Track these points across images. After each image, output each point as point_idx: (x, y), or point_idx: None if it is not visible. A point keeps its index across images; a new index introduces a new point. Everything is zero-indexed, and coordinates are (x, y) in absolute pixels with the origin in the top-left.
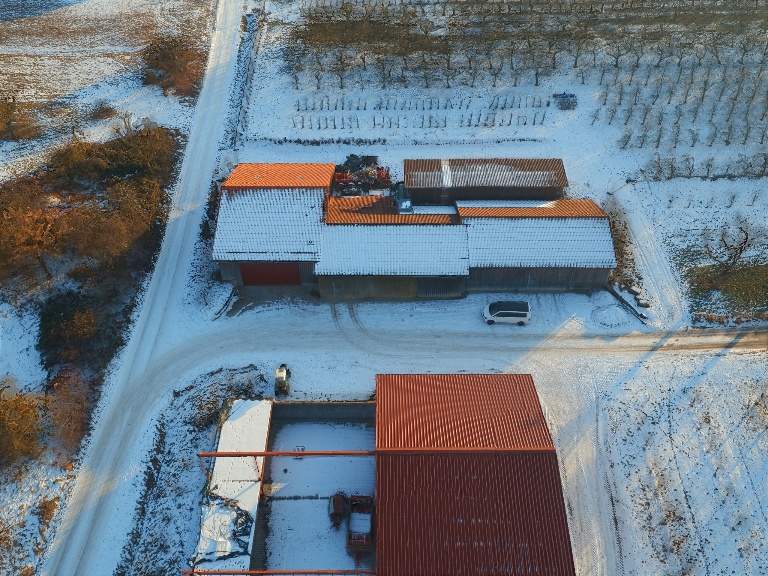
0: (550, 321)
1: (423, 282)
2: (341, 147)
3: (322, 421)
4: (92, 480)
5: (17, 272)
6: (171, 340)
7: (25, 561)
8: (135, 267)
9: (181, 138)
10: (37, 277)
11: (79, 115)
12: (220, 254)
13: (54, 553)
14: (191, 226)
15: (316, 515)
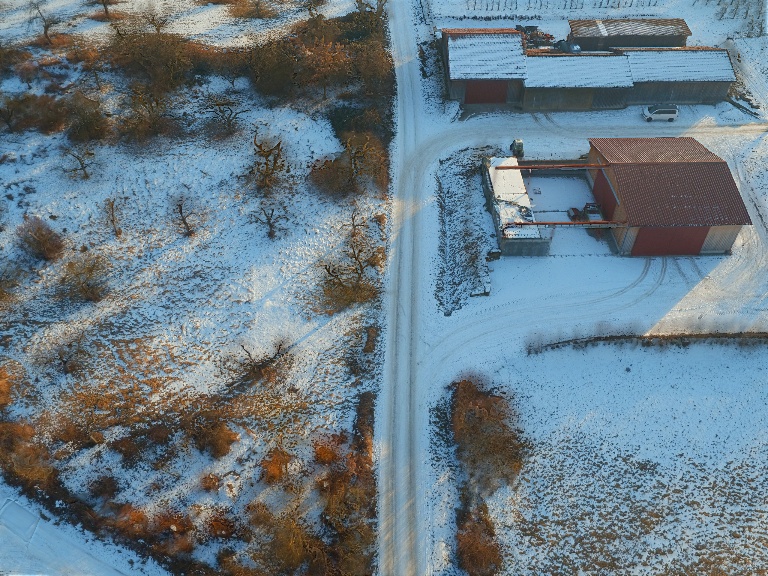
0: (690, 119)
1: (598, 95)
2: (507, 22)
3: (546, 176)
4: (403, 205)
5: (300, 96)
6: (426, 133)
7: (377, 244)
8: (384, 92)
9: (383, 18)
10: (315, 99)
11: (299, 3)
12: (456, 75)
13: (395, 240)
14: (413, 70)
15: (561, 219)
